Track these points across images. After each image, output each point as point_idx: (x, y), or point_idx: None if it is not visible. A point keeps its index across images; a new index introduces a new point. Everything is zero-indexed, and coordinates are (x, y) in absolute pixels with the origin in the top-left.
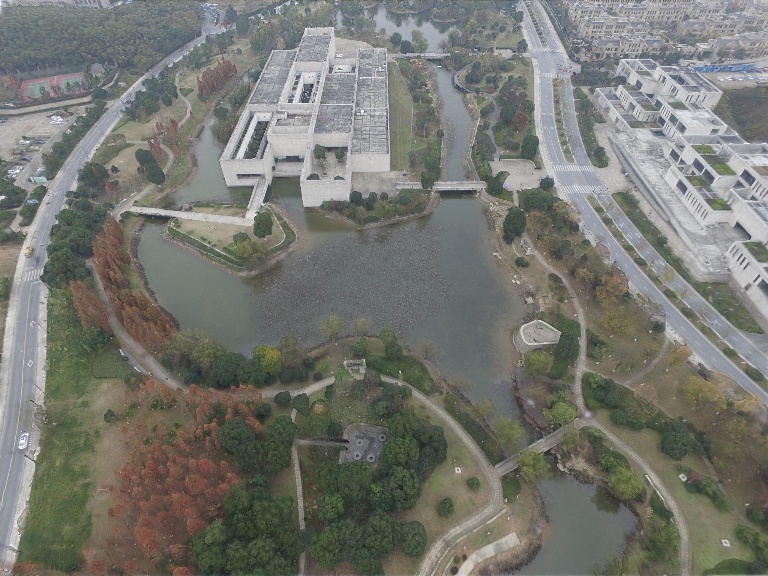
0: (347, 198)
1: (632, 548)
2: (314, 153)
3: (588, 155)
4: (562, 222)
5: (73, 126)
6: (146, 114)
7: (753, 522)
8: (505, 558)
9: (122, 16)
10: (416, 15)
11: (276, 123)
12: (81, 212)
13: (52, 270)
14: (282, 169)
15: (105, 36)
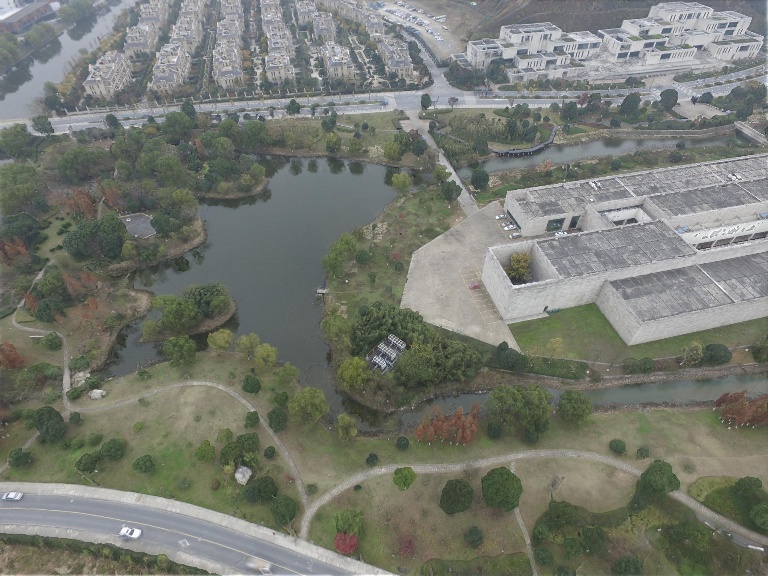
0: None
1: None
2: None
3: None
4: None
5: None
6: None
7: None
8: None
9: None
10: None
11: None
12: None
13: None
14: None
15: None
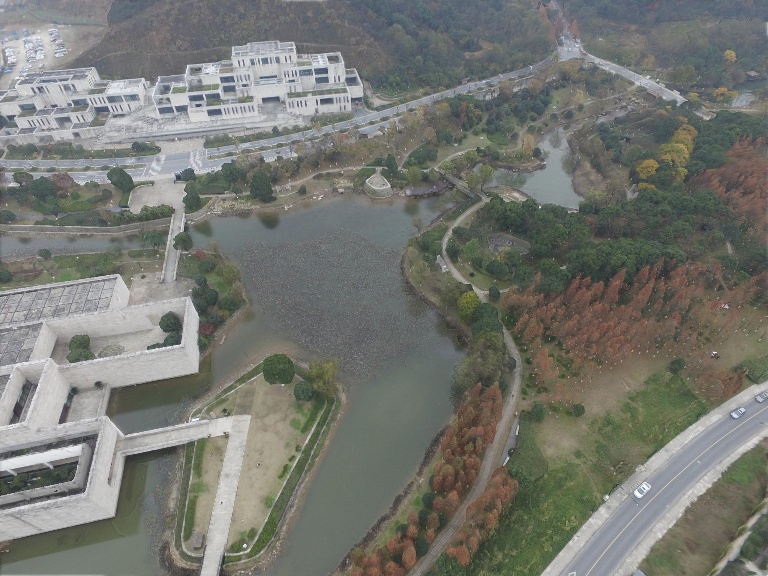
0: (197, 316)
1: (496, 164)
2: None
3: (135, 156)
4: None
5: None
6: None
7: (469, 130)
8: (526, 197)
9: None
10: None
11: None
12: None
13: None
14: None
15: None
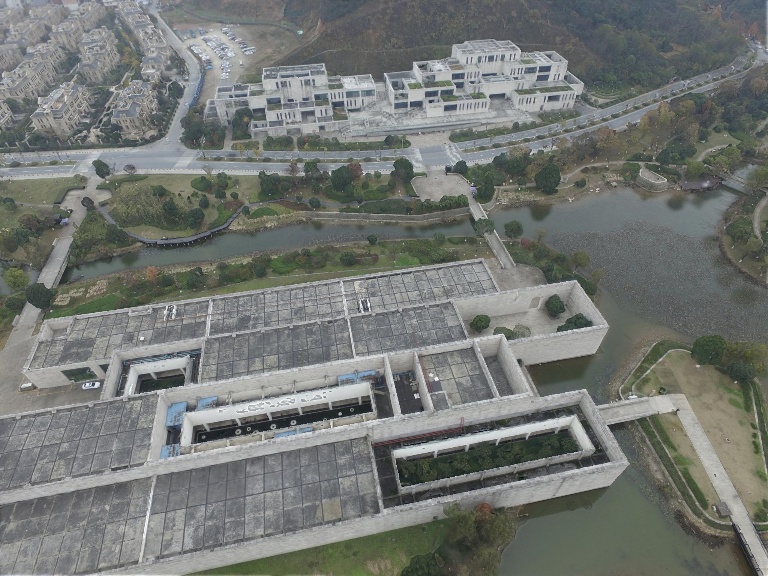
0: None
1: (752, 160)
2: None
3: (389, 149)
4: (528, 158)
5: None
6: None
7: (709, 128)
8: None
9: None
10: None
11: None
12: None
13: None
14: None
15: None
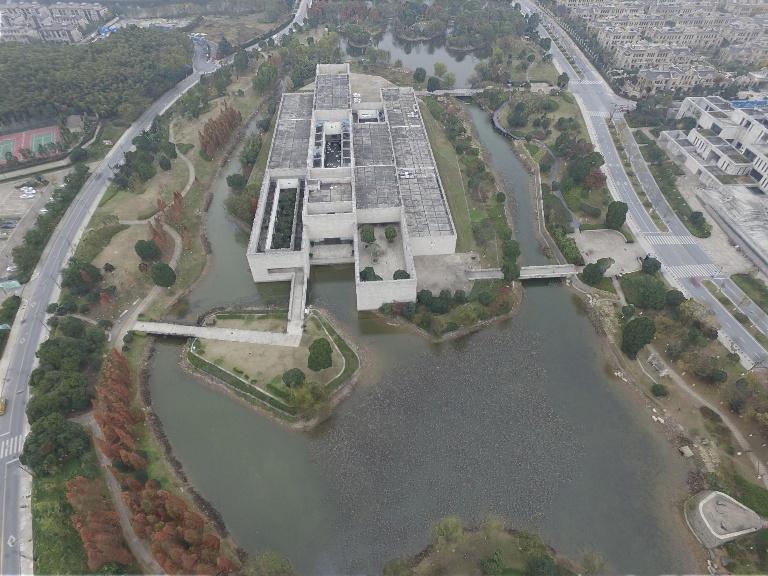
0: (413, 298)
1: None
2: (362, 236)
3: (681, 220)
4: (696, 328)
5: (50, 204)
6: (140, 182)
7: None
8: None
9: (100, 55)
10: (427, 41)
11: (308, 196)
12: (70, 343)
13: (36, 450)
14: (321, 255)
15: (82, 81)
